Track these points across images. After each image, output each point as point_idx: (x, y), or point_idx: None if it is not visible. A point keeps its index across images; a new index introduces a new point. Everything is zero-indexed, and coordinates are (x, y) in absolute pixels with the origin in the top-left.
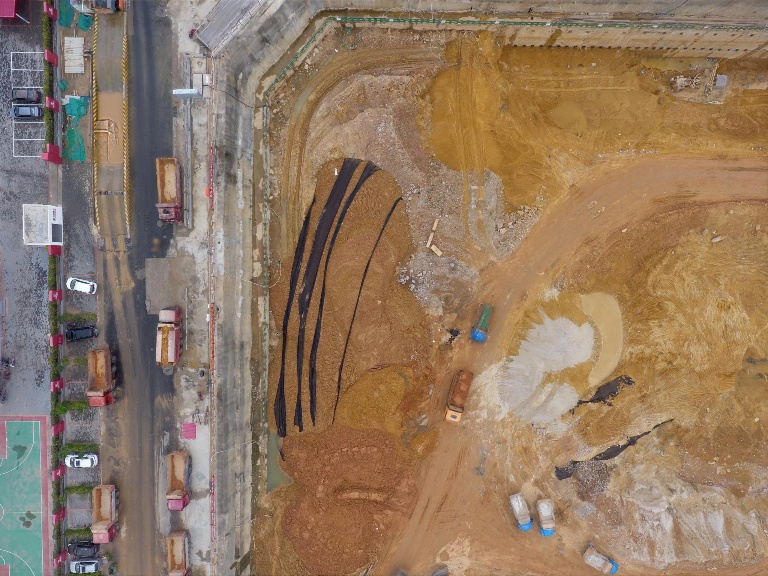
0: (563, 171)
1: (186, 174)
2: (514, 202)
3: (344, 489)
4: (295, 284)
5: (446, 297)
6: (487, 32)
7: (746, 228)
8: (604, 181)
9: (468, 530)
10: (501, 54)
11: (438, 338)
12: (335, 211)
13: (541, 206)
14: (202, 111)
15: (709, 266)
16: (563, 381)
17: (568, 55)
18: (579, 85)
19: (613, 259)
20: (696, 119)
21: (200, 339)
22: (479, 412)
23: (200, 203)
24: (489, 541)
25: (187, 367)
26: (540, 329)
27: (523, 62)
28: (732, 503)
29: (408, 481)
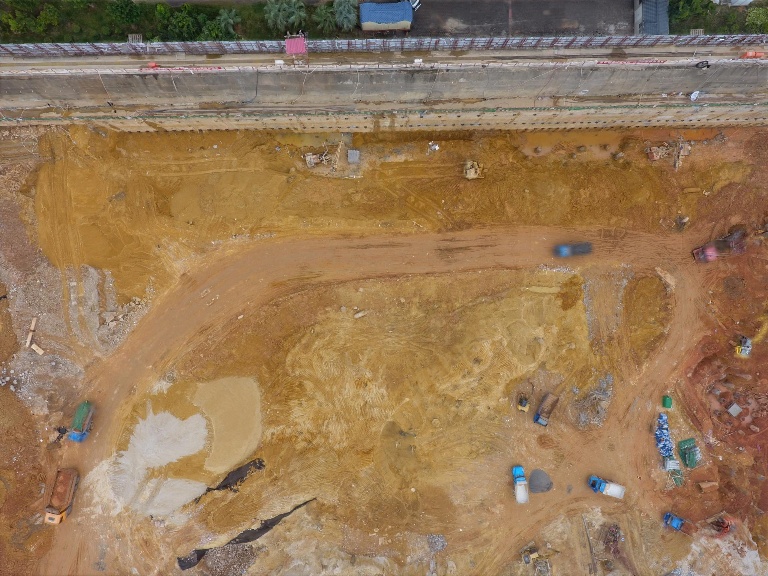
0: (173, 260)
1: None
2: (126, 294)
3: None
4: None
5: (50, 396)
6: (77, 125)
7: (389, 302)
8: (218, 268)
9: None
10: (116, 141)
11: (46, 437)
12: None
13: (149, 298)
14: None
15: (355, 341)
16: (167, 476)
17: (187, 139)
18: (201, 168)
19: (231, 346)
20: (329, 196)
21: None
22: (93, 508)
23: None
24: None
25: None
26: (142, 425)
27: (142, 147)
28: (393, 573)
29: None
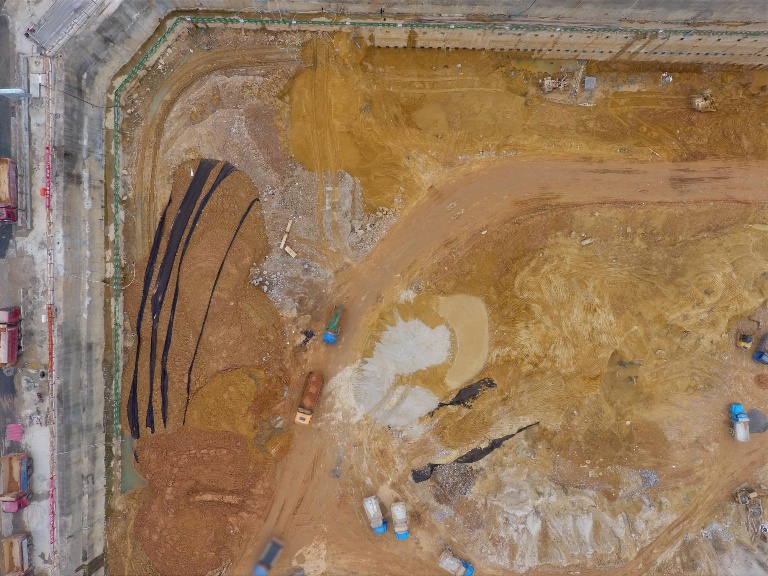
0: (422, 173)
1: (21, 174)
2: (373, 203)
3: (197, 491)
4: (148, 285)
5: (300, 299)
6: (342, 33)
7: (616, 230)
8: (464, 183)
9: (324, 533)
10: (365, 55)
11: (292, 340)
12: (190, 212)
13: (398, 208)
14: (40, 111)
15: (579, 268)
16: (415, 383)
17: (433, 56)
18: (444, 86)
19: (473, 261)
20: (564, 121)
21: (40, 340)
22: (334, 414)
23: (39, 203)
24: (346, 544)
25: (28, 368)
26: (392, 331)
27: (388, 63)
28: (603, 506)
29: (263, 483)
